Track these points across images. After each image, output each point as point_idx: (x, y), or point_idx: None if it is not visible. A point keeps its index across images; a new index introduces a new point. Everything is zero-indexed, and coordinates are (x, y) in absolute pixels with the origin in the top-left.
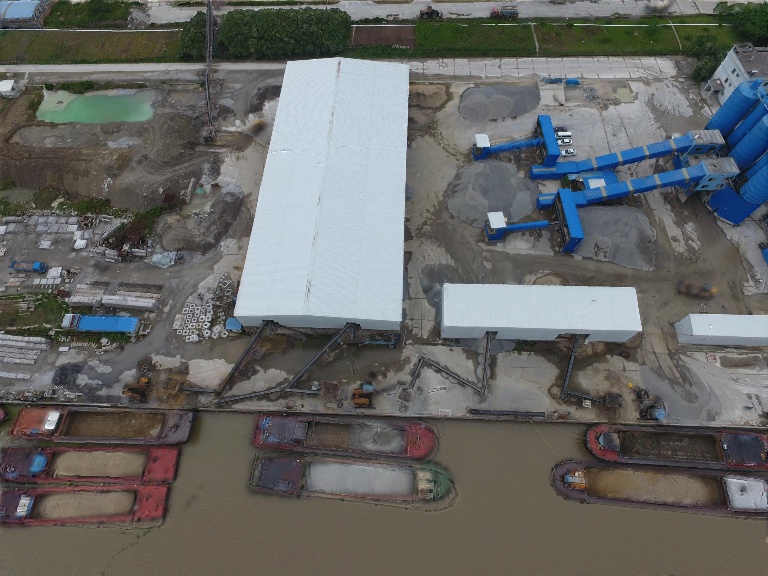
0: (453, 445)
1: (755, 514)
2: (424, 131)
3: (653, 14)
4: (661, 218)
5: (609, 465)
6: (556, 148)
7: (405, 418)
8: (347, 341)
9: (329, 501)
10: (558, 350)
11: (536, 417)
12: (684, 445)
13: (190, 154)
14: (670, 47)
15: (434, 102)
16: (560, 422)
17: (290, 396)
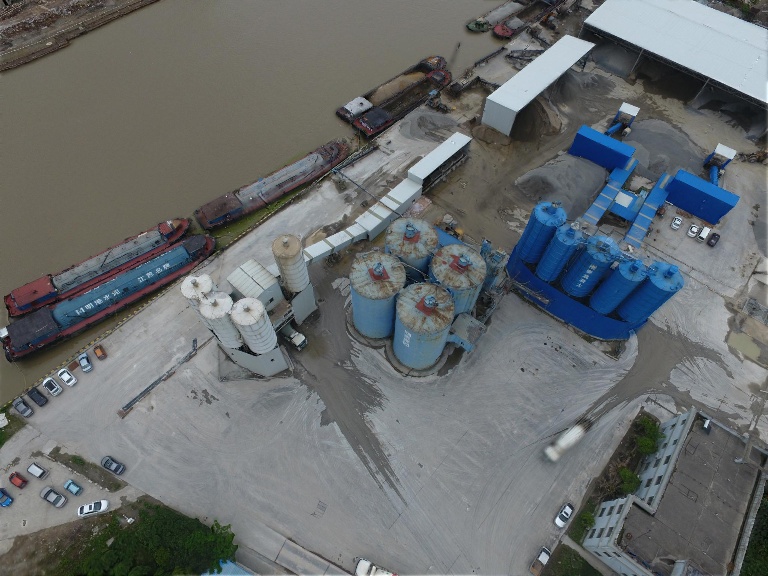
0: None
1: None
2: None
3: None
4: None
5: None
6: (685, 180)
7: None
8: None
9: (507, 1)
10: None
11: None
12: None
13: None
14: None
15: None
16: None
17: (571, 7)
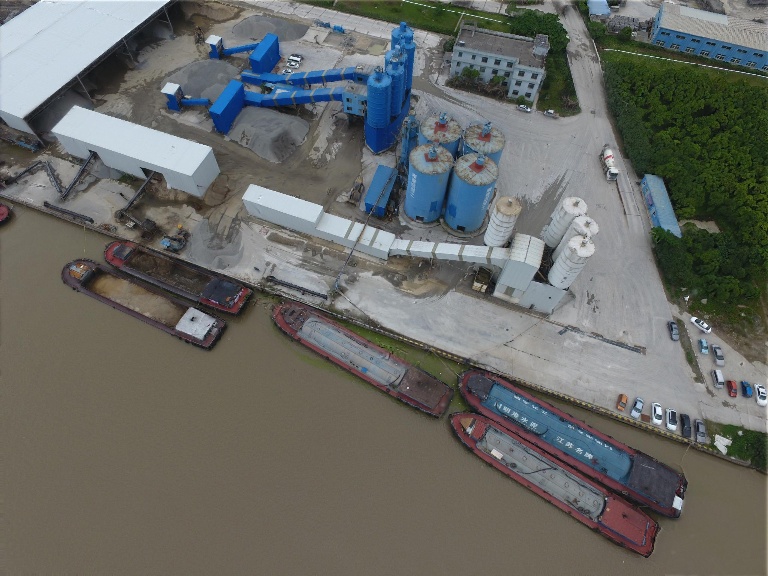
0: (15, 222)
1: (194, 339)
2: (194, 32)
3: (457, 4)
4: (320, 133)
5: (118, 273)
6: (259, 56)
7: (2, 198)
8: (1, 135)
9: None
10: (150, 189)
11: (86, 221)
12: (191, 282)
13: (11, 2)
14: (446, 27)
15: (218, 16)
16: (109, 235)
17: None
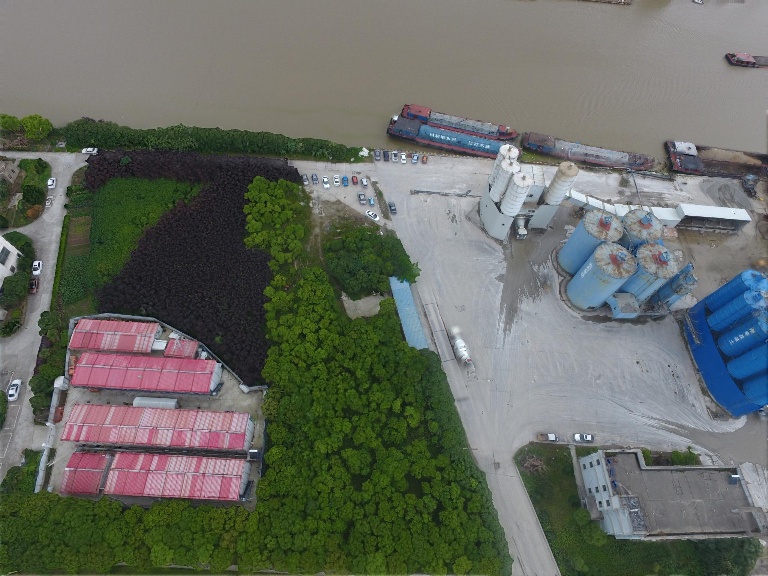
0: None
1: None
2: None
3: None
4: None
5: None
6: None
7: None
8: None
9: None
10: None
11: None
12: None
13: None
14: None
15: None
16: None
17: None
